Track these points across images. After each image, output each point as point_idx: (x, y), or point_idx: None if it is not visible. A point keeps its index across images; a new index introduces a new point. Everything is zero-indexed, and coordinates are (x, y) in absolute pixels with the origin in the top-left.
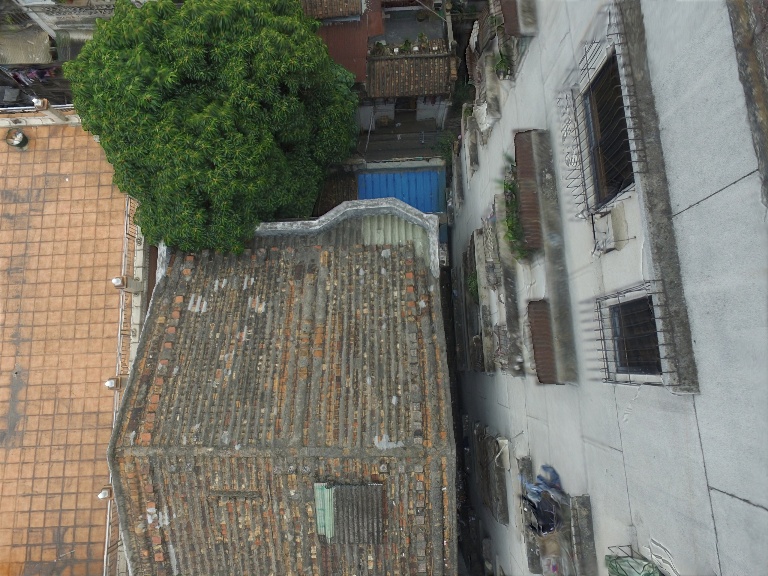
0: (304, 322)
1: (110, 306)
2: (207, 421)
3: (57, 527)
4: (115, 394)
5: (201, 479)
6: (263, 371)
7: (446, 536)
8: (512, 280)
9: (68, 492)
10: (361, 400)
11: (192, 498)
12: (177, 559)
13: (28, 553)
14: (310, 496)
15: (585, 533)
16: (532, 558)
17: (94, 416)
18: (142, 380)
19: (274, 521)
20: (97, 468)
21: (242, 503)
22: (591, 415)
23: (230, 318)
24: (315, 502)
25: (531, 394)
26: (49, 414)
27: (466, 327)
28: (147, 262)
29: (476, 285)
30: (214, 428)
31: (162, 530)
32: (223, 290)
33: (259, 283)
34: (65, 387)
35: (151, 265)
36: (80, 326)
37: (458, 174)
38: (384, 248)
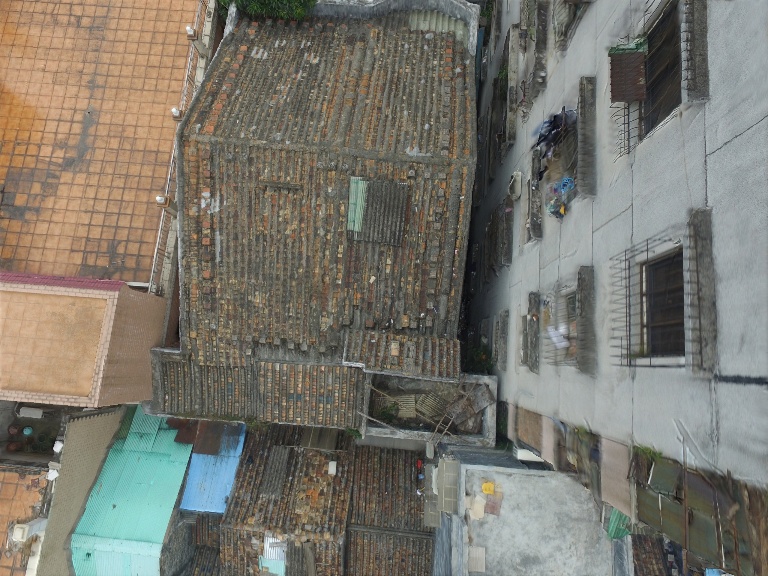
0: (353, 71)
1: (177, 66)
2: (263, 125)
3: (112, 240)
4: (177, 125)
5: (252, 170)
6: (314, 99)
7: (458, 245)
8: (545, 12)
9: (124, 213)
10: (398, 124)
11: (242, 188)
12: (221, 247)
13: (85, 258)
14: (345, 194)
15: (589, 101)
16: (534, 225)
17: (154, 154)
18: (208, 94)
19: (310, 216)
20: (152, 196)
21: (285, 195)
22: (606, 2)
23: (287, 65)
24: (349, 196)
25: (550, 92)
26: (114, 148)
27: (488, 151)
28: (213, 35)
29: (507, 72)
30: (268, 130)
31: (212, 216)
32: (282, 47)
33: (315, 46)
34: (131, 128)
35: (216, 42)
36: (149, 80)
37: (498, 11)
38: (428, 32)
